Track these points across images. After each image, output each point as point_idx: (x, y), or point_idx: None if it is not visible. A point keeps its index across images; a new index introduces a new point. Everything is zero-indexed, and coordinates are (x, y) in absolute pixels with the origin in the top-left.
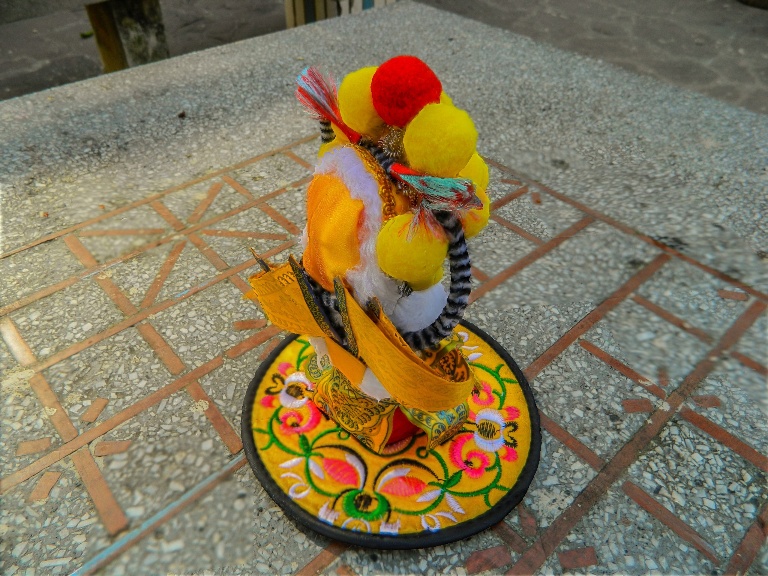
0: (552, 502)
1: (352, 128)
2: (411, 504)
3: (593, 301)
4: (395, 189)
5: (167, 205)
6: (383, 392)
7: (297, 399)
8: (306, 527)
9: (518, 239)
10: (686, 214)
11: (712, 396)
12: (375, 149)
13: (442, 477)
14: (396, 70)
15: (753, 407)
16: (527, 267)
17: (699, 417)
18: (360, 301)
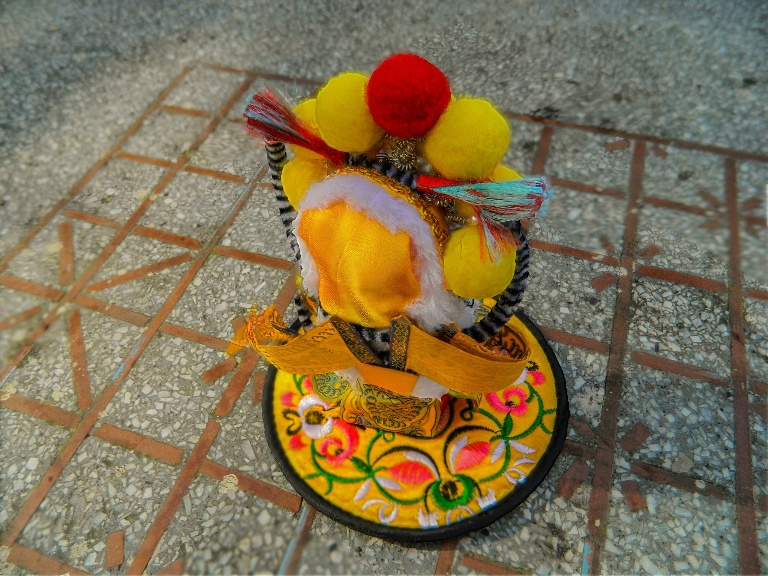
0: (590, 401)
1: (344, 151)
2: (489, 468)
3: None
4: (425, 203)
5: (20, 275)
6: (441, 390)
7: (322, 425)
8: (416, 542)
9: None
10: (542, 80)
11: (650, 245)
12: (379, 165)
13: (497, 429)
14: (405, 79)
15: (682, 241)
16: None
17: (651, 269)
18: (429, 330)
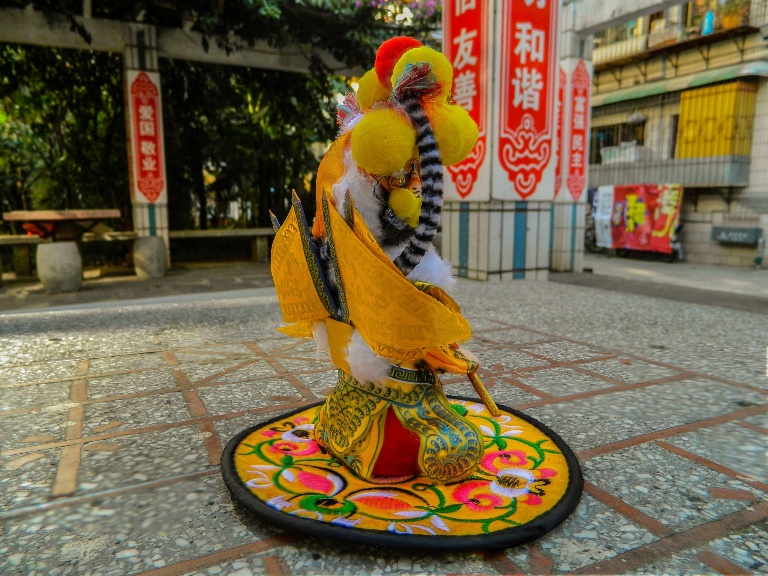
0: (582, 551)
1: None
2: (383, 512)
3: (681, 420)
4: None
5: (259, 345)
6: (366, 354)
7: (300, 438)
8: (249, 510)
9: (596, 380)
10: None
11: None
12: None
13: (435, 505)
14: None
15: None
16: (601, 395)
17: None
18: (339, 210)
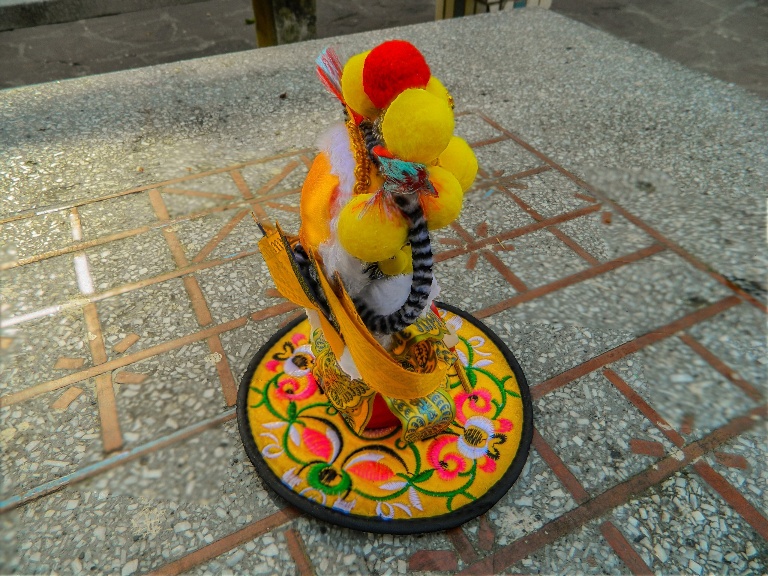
0: (518, 522)
1: (352, 108)
2: (372, 489)
3: (634, 332)
4: (376, 171)
5: (244, 175)
6: (357, 372)
7: (300, 369)
8: (268, 485)
9: (572, 256)
10: None
11: (739, 456)
12: (369, 130)
13: (412, 471)
14: (383, 52)
15: None
16: (572, 285)
17: (715, 475)
18: (328, 274)
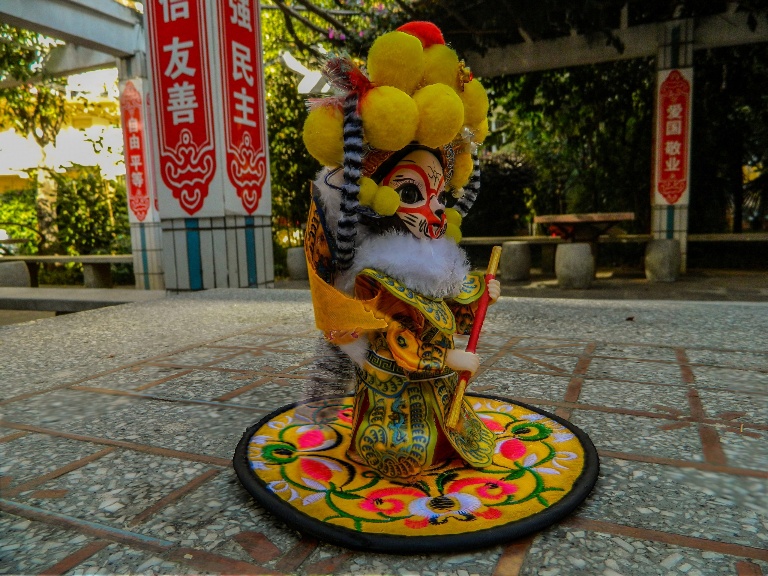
0: None
1: None
2: (295, 473)
3: None
4: None
5: (521, 341)
6: (338, 334)
7: None
8: None
9: None
10: None
11: None
12: None
13: (345, 488)
14: None
15: None
16: None
17: None
18: None
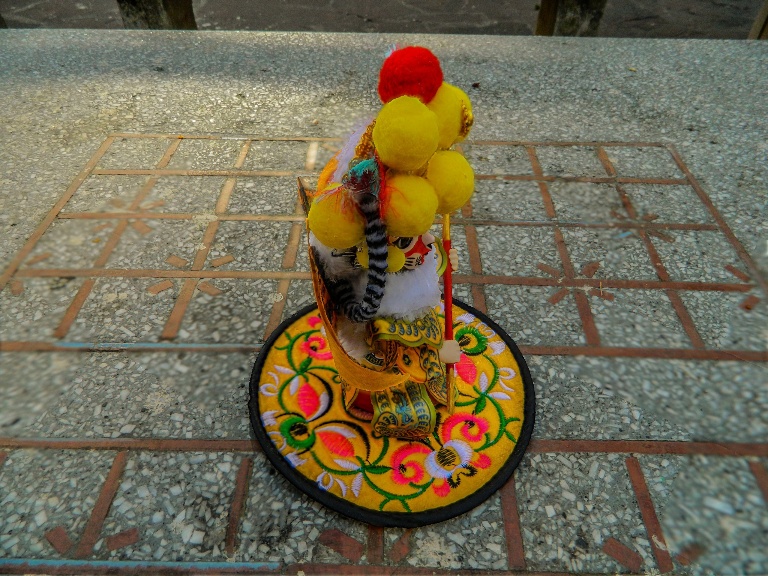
0: (438, 553)
1: None
2: (327, 458)
3: (693, 433)
4: None
5: None
6: None
7: None
8: None
9: (676, 329)
10: None
11: None
12: None
13: (371, 460)
14: (396, 56)
15: None
16: (654, 359)
17: None
18: None
